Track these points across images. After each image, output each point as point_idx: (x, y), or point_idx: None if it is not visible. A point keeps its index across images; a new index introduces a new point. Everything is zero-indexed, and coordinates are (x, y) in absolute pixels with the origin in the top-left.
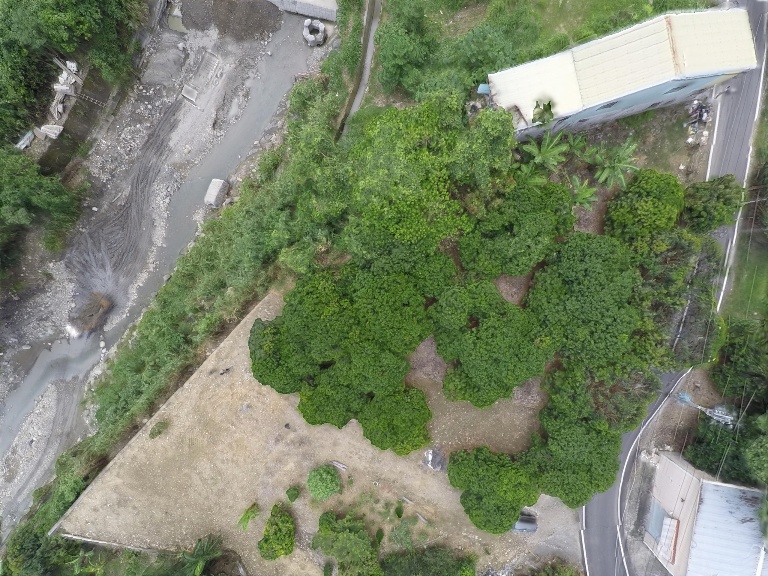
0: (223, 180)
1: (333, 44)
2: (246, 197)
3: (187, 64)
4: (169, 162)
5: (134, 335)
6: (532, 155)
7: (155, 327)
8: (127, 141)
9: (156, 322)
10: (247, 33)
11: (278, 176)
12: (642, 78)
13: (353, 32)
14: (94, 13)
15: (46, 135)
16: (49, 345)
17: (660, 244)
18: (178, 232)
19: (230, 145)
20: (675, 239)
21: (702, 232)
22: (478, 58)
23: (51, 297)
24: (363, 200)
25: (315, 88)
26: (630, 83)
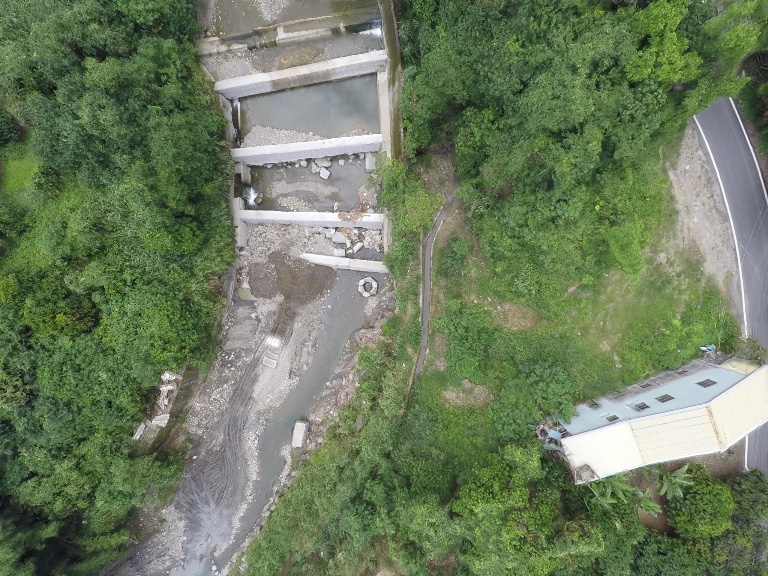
0: (305, 423)
1: (386, 295)
2: (333, 449)
3: (260, 327)
4: (254, 410)
5: (243, 561)
6: (602, 481)
7: (265, 562)
8: (217, 400)
9: (267, 562)
10: (310, 298)
11: (357, 426)
12: (692, 447)
13: (413, 319)
14: (191, 335)
15: (157, 426)
16: (167, 573)
17: (721, 554)
18: (269, 466)
19: (305, 387)
20: (733, 545)
21: (752, 523)
22: (542, 395)
23: (166, 536)
24: (479, 573)
25: (383, 357)
26: (682, 450)
